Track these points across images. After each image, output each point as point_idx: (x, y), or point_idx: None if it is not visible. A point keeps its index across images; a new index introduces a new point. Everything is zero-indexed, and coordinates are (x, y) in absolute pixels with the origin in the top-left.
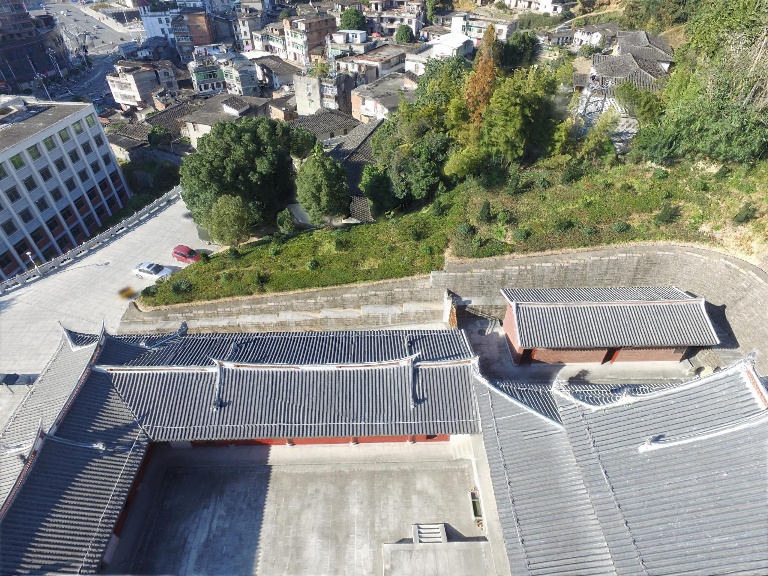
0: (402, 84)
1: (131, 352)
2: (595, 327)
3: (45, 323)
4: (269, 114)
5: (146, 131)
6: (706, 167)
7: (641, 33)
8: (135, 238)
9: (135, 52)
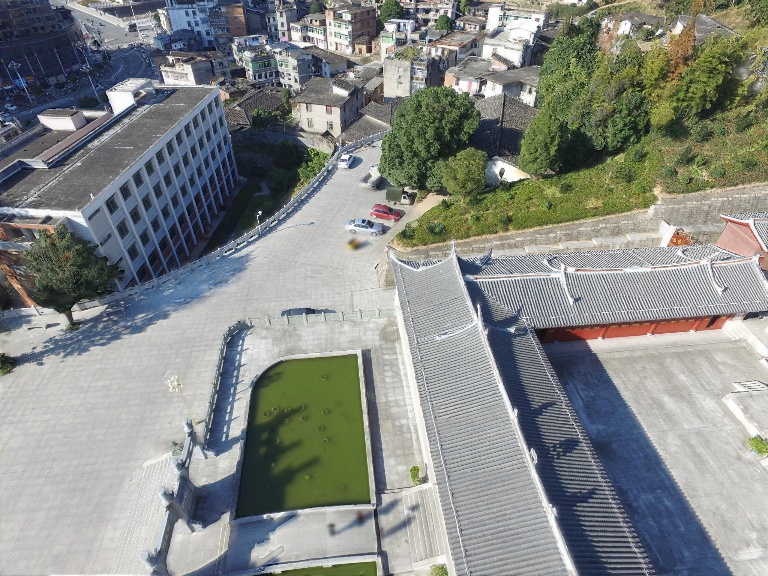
0: (487, 66)
1: (473, 268)
2: None
3: (295, 271)
4: None
5: (240, 115)
6: None
7: (703, 16)
8: (322, 202)
9: (168, 44)
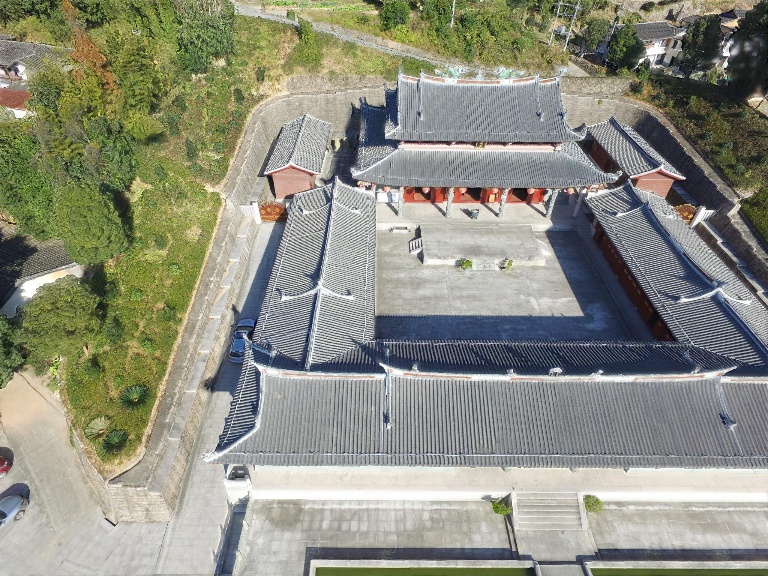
0: None
1: (281, 362)
2: (313, 147)
3: None
4: None
5: None
6: (218, 64)
7: None
8: None
9: None
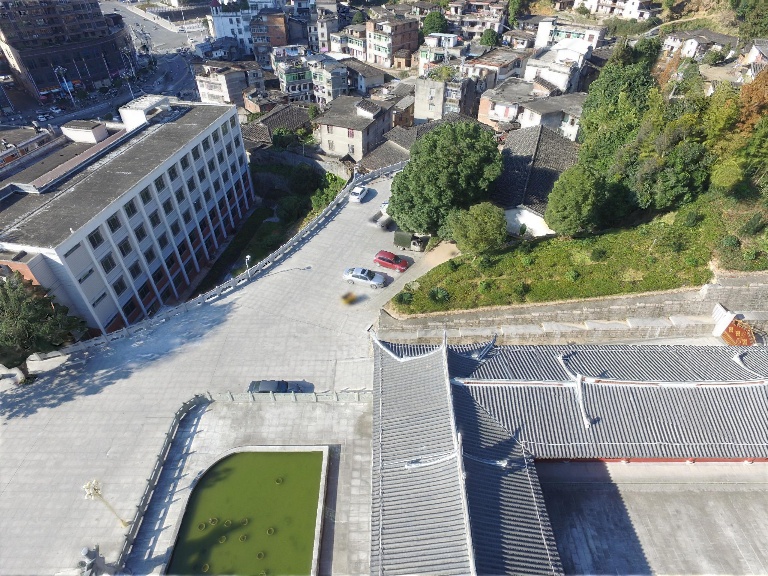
0: (528, 89)
1: (468, 364)
2: None
3: (278, 328)
4: (391, 117)
5: (263, 132)
6: None
7: None
8: (324, 242)
9: (209, 52)
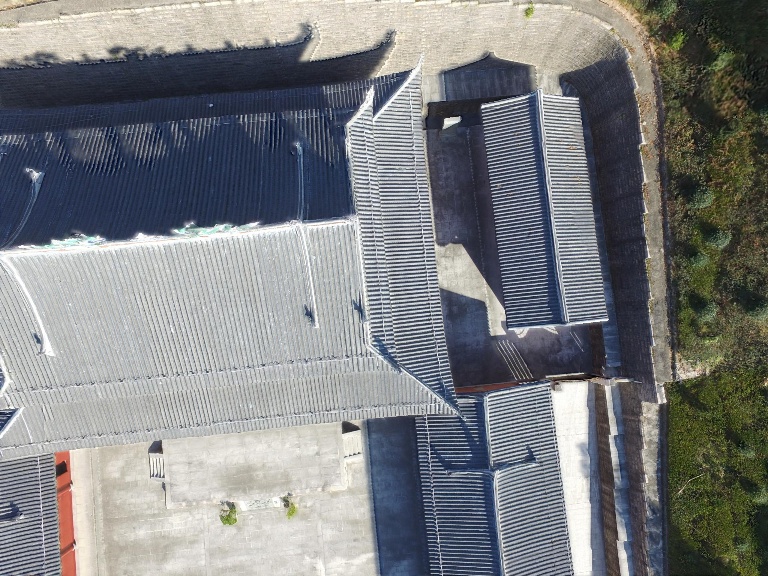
0: None
1: None
2: None
3: None
4: None
5: None
6: None
7: None
8: None
9: None
